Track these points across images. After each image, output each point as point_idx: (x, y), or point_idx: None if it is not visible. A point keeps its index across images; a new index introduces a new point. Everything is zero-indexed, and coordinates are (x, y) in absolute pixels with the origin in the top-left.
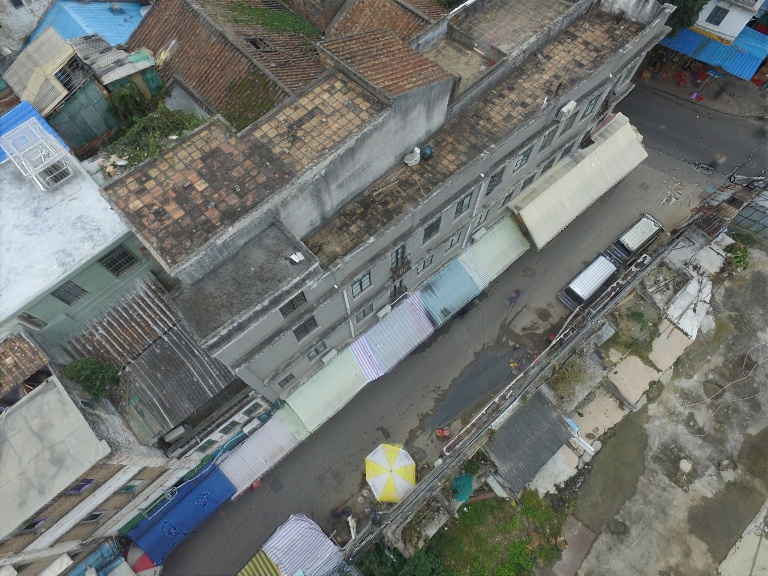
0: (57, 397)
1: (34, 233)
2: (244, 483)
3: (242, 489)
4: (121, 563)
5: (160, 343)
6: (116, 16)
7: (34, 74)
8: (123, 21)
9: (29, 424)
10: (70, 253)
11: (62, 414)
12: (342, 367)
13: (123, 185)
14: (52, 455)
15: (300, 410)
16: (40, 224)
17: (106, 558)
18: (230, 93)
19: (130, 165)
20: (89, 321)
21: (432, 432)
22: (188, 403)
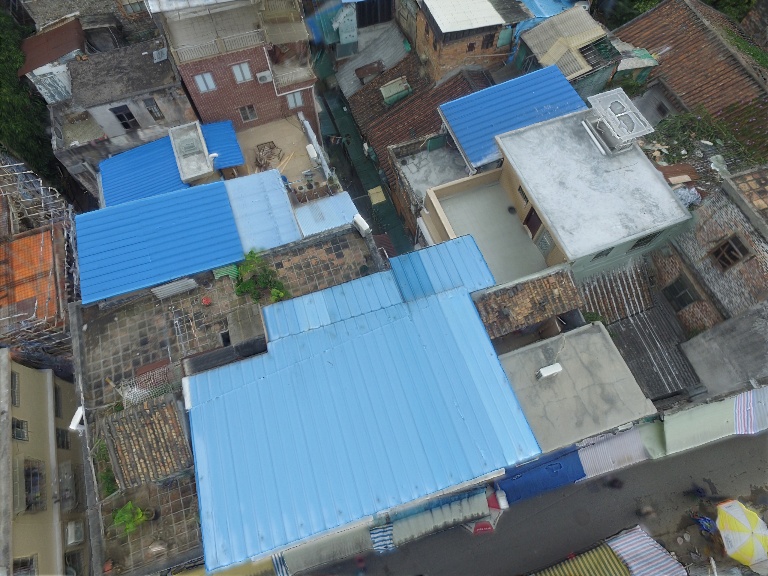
0: (602, 342)
1: (597, 189)
2: (590, 473)
3: (586, 477)
4: (482, 492)
5: (626, 322)
6: (557, 3)
7: (557, 42)
8: (562, 9)
9: (579, 355)
10: (632, 219)
11: (609, 359)
12: (719, 409)
13: (744, 181)
14: (603, 392)
15: (669, 431)
16: (602, 183)
17: (483, 483)
18: (728, 114)
19: (670, 155)
20: (583, 279)
21: (764, 509)
22: (647, 388)
